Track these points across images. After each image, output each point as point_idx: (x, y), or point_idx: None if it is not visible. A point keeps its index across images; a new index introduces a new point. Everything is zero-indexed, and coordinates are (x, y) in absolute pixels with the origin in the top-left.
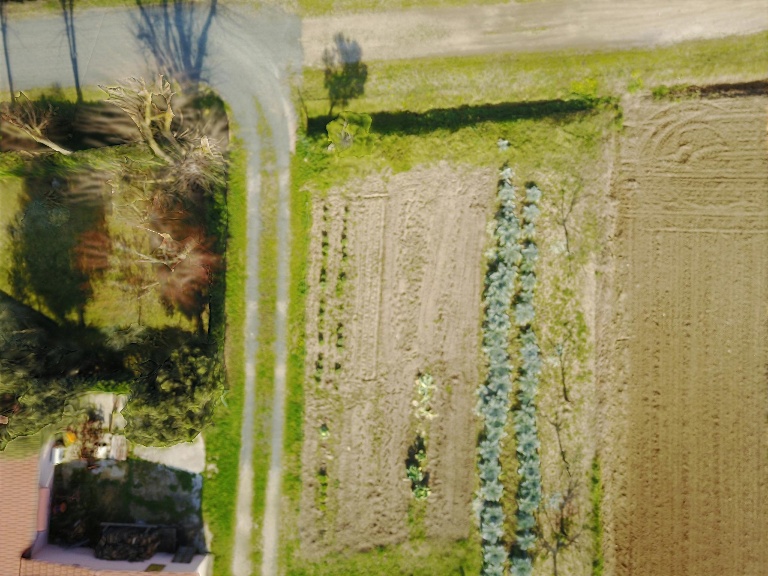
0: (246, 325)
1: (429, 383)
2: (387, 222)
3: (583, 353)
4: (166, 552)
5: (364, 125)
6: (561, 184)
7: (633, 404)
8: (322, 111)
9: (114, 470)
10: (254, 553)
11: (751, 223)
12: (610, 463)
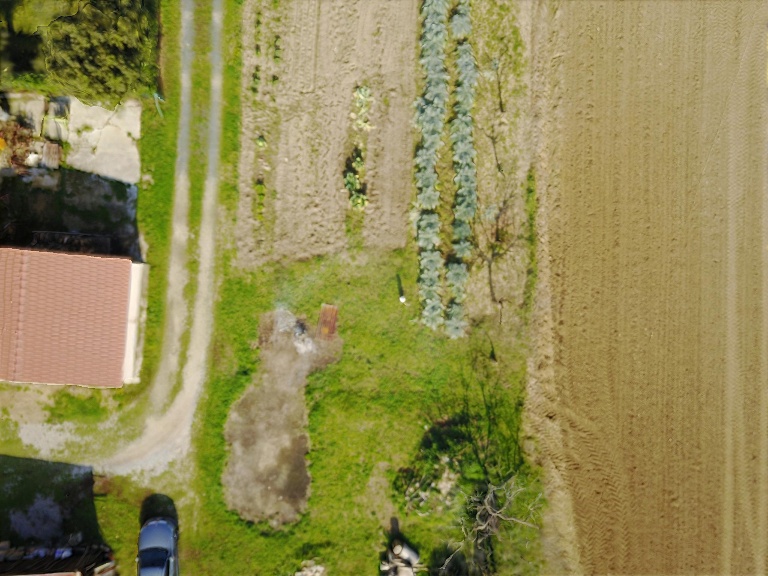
0: (182, 36)
1: (367, 95)
2: None
3: (519, 67)
4: None
5: None
6: None
7: (567, 118)
8: None
9: (46, 179)
10: (190, 262)
11: None
12: (545, 177)
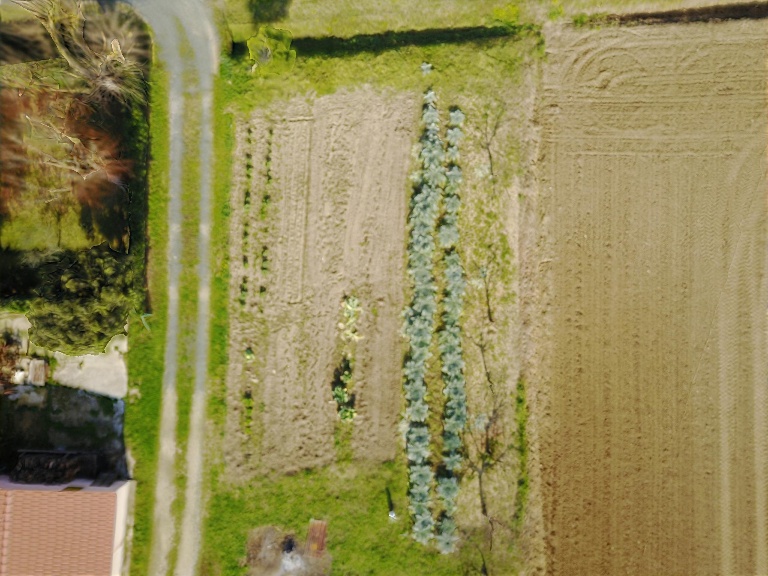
0: (169, 248)
1: (355, 305)
2: (312, 145)
3: (507, 275)
4: (86, 479)
5: (284, 41)
6: (485, 108)
7: (556, 324)
8: (248, 36)
9: (32, 396)
10: (177, 478)
11: (668, 146)
12: (534, 384)
